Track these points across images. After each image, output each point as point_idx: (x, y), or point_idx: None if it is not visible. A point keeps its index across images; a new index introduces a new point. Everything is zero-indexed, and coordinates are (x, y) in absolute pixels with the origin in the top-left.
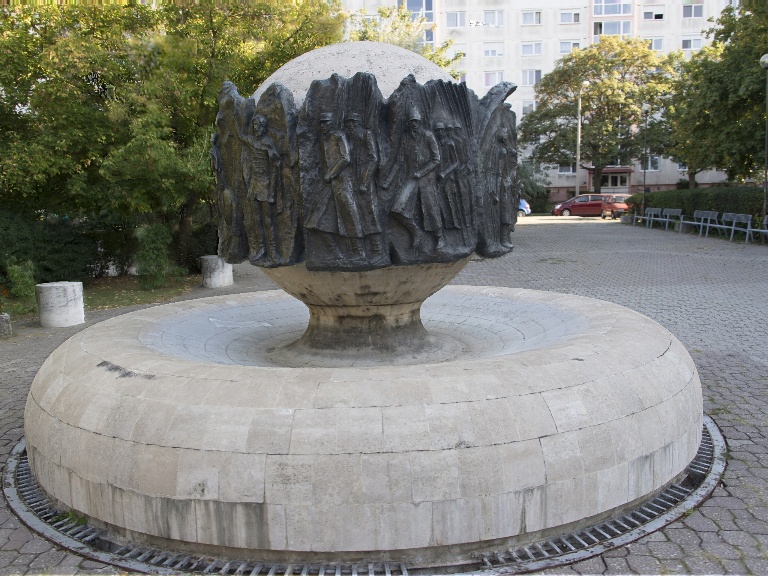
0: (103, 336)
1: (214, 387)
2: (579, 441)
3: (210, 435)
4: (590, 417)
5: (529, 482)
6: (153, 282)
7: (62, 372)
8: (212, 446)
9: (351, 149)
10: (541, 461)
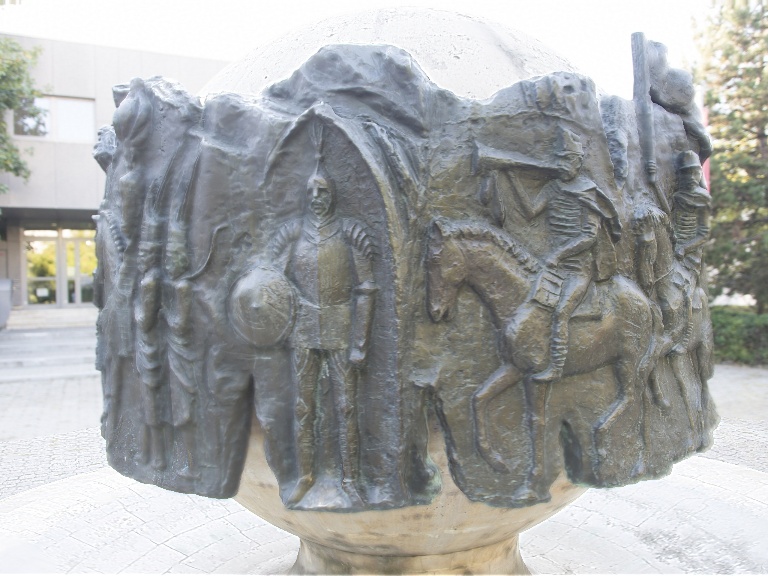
0: None
1: None
2: None
3: None
4: None
5: None
6: None
7: None
8: None
9: None
10: None
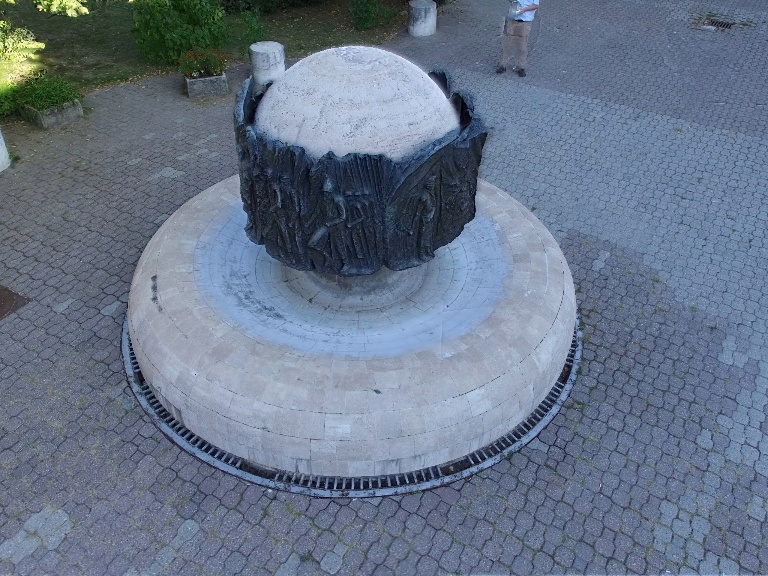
0: (181, 231)
1: (177, 337)
2: (337, 446)
3: (164, 368)
4: (351, 435)
5: (300, 456)
6: (364, 23)
7: None
8: (164, 374)
9: (283, 199)
10: (309, 450)
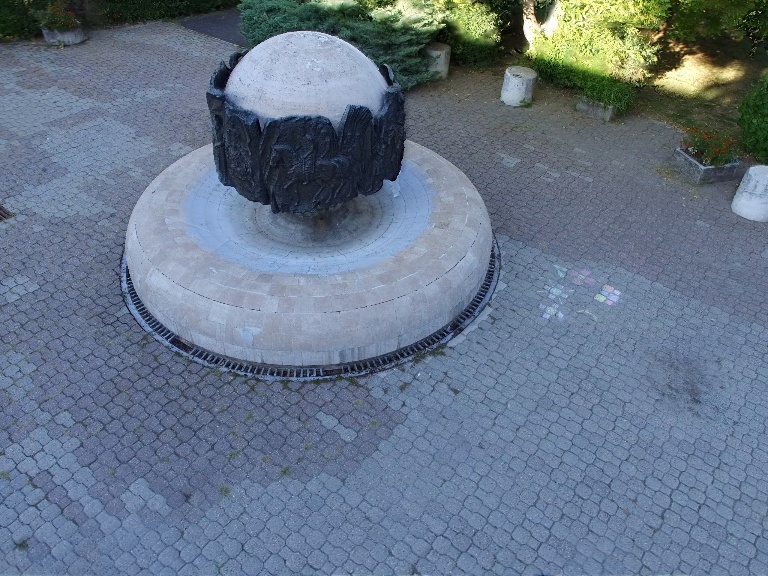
0: None
1: None
2: None
3: None
4: None
5: None
6: None
7: None
8: None
9: None
10: None
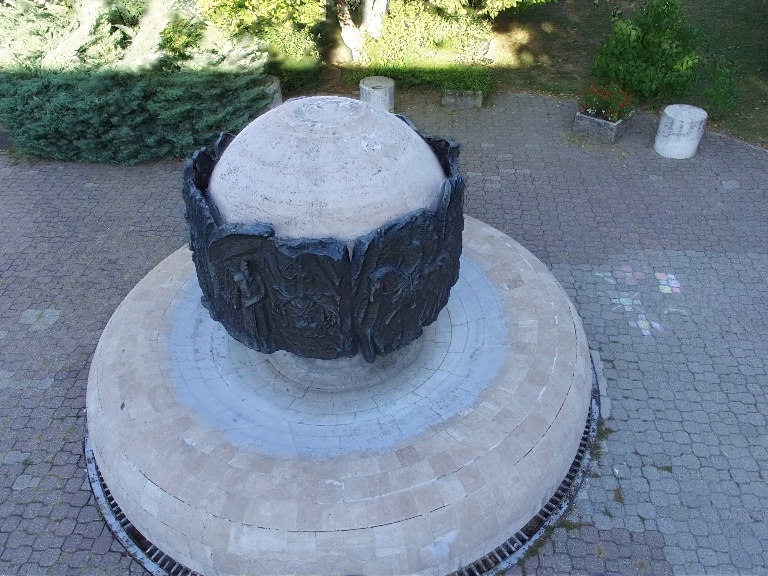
0: None
1: (158, 268)
2: None
3: None
4: None
5: None
6: None
7: None
8: None
9: None
10: None
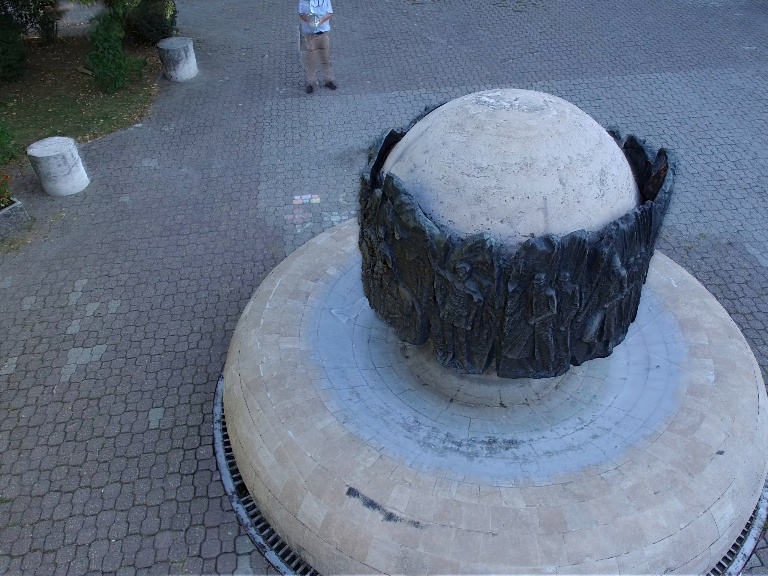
0: (298, 414)
1: (482, 543)
2: (729, 534)
3: None
4: (736, 514)
5: (700, 572)
6: (114, 84)
7: (307, 490)
8: None
9: None
10: (709, 559)
